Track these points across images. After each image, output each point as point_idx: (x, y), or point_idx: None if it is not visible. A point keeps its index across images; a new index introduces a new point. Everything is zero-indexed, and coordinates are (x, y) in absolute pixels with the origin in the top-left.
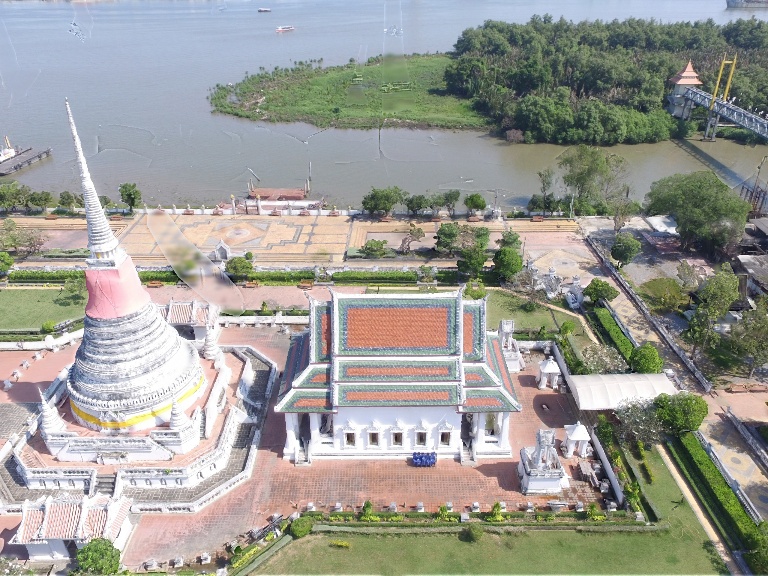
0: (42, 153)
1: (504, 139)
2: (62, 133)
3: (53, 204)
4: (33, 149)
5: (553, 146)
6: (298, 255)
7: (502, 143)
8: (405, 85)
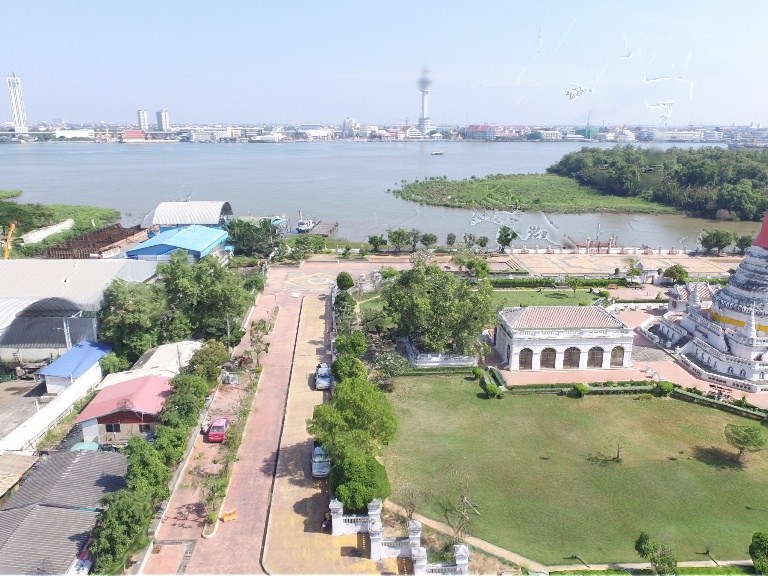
0: (336, 224)
1: (709, 219)
2: (349, 208)
3: (436, 245)
4: (322, 222)
5: (755, 223)
6: (692, 273)
7: (711, 221)
8: (658, 167)
